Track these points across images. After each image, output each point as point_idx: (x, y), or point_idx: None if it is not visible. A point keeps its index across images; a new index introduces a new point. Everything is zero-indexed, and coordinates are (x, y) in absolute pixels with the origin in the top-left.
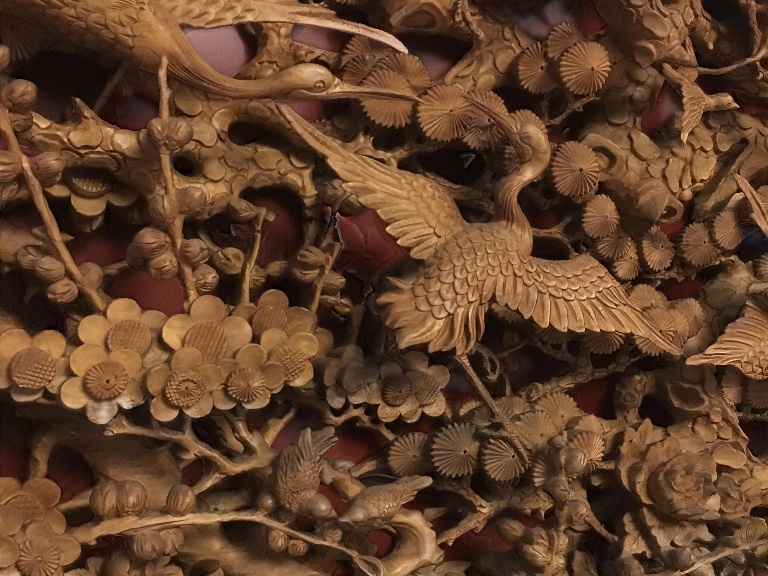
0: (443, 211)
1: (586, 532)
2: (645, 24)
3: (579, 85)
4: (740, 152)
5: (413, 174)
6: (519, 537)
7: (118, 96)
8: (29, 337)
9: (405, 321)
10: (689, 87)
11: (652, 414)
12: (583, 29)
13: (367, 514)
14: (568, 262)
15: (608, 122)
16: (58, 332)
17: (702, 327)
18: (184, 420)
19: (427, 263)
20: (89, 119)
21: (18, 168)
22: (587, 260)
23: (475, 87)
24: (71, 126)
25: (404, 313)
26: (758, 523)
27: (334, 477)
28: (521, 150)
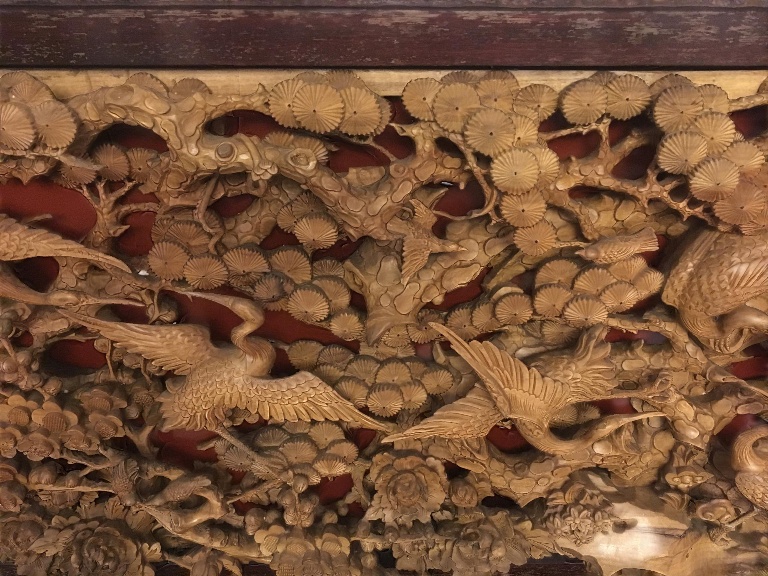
0: (192, 349)
1: None
2: (341, 217)
3: None
4: None
5: (170, 327)
6: None
7: (12, 264)
8: None
9: (167, 416)
10: (412, 241)
11: None
12: (364, 160)
13: (163, 502)
14: (286, 379)
15: None
16: None
17: (466, 378)
18: (62, 449)
19: (186, 378)
20: None
21: None
22: (304, 376)
23: (260, 224)
24: None
25: (167, 410)
26: (475, 513)
27: (155, 474)
28: None
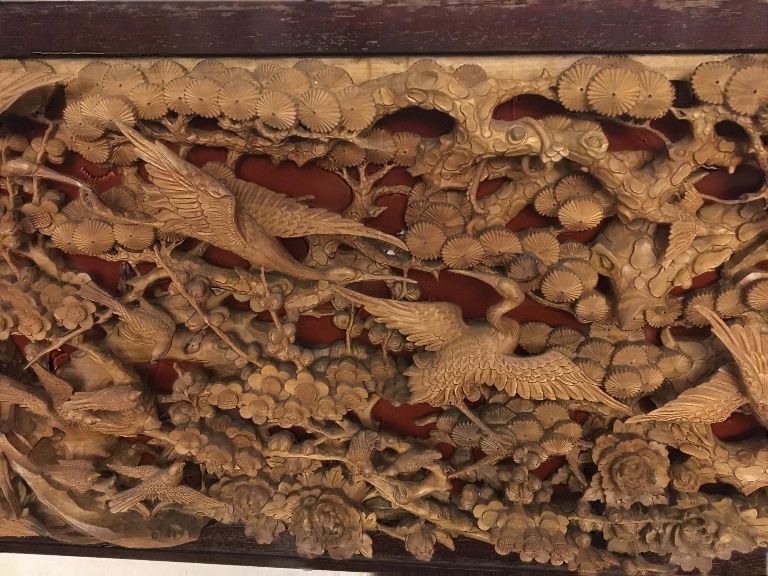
0: (447, 326)
1: (585, 464)
2: (620, 199)
3: (574, 227)
4: None
5: (427, 304)
6: (506, 481)
7: None
8: (225, 386)
9: (415, 389)
10: (680, 224)
11: (648, 407)
12: (620, 145)
13: (397, 472)
14: (536, 358)
15: (626, 225)
16: (237, 384)
17: (698, 363)
18: None
19: (436, 354)
20: (243, 279)
21: (203, 324)
22: (554, 355)
23: (510, 207)
24: (237, 280)
25: (416, 384)
26: (699, 499)
27: (387, 446)
28: (501, 294)
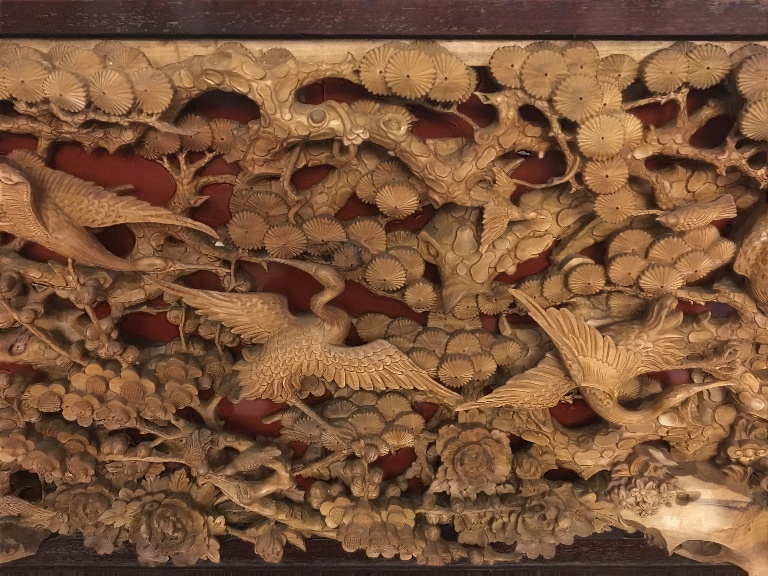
0: (271, 317)
1: (437, 456)
2: (427, 183)
3: (392, 214)
4: (592, 219)
5: (250, 295)
6: (352, 476)
7: None
8: (46, 387)
9: (244, 384)
10: (492, 209)
11: None
12: (440, 132)
13: (234, 471)
14: (363, 347)
15: (450, 213)
16: (59, 384)
17: (533, 350)
18: None
19: (263, 346)
20: (57, 273)
21: (12, 320)
22: (380, 344)
23: (336, 195)
24: (52, 274)
25: (244, 379)
26: (540, 485)
27: (225, 445)
28: (320, 282)
